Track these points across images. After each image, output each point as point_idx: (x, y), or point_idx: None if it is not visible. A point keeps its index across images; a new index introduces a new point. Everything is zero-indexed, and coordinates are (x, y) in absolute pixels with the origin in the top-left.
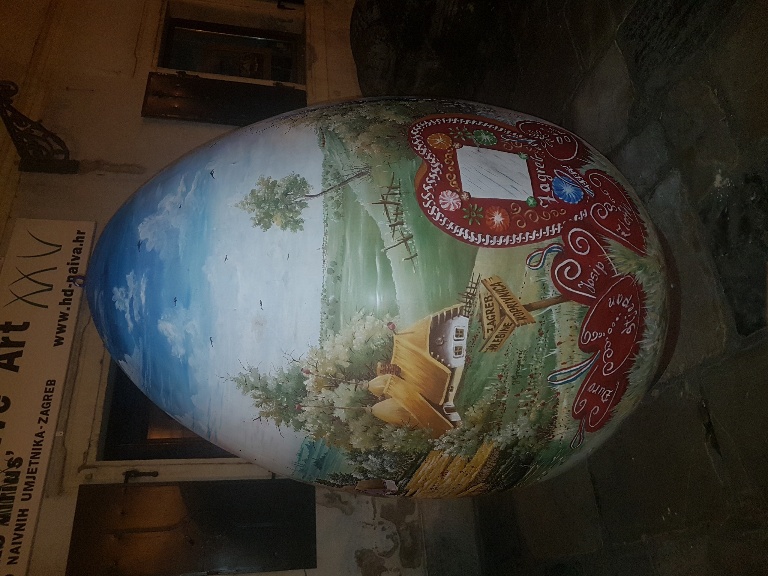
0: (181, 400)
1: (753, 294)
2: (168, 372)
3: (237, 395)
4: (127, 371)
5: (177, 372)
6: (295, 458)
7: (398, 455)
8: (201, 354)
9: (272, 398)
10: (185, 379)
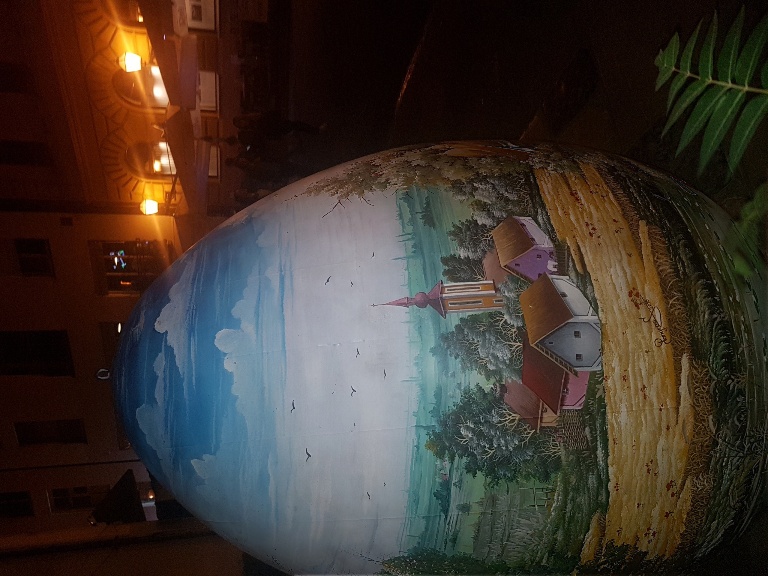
0: (243, 259)
1: (703, 173)
2: (228, 242)
3: (309, 200)
4: (165, 325)
5: (239, 233)
6: (397, 227)
7: (503, 177)
8: (265, 205)
9: (346, 183)
10: (249, 230)
